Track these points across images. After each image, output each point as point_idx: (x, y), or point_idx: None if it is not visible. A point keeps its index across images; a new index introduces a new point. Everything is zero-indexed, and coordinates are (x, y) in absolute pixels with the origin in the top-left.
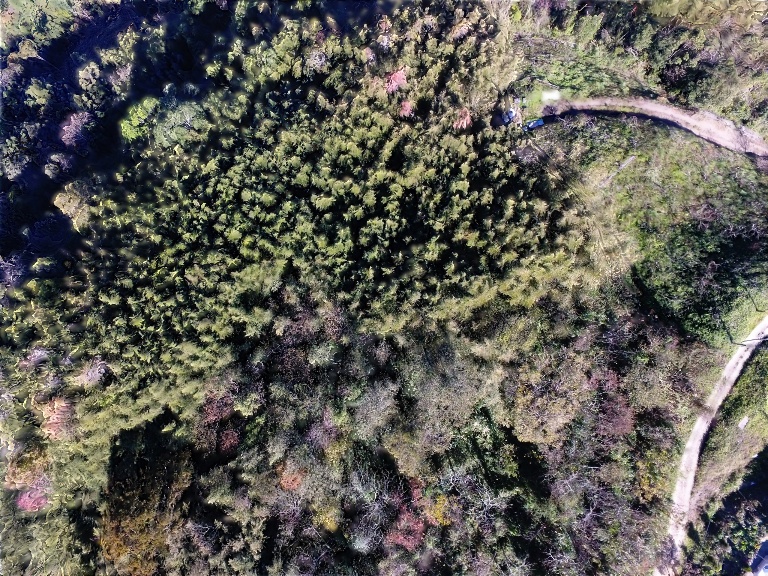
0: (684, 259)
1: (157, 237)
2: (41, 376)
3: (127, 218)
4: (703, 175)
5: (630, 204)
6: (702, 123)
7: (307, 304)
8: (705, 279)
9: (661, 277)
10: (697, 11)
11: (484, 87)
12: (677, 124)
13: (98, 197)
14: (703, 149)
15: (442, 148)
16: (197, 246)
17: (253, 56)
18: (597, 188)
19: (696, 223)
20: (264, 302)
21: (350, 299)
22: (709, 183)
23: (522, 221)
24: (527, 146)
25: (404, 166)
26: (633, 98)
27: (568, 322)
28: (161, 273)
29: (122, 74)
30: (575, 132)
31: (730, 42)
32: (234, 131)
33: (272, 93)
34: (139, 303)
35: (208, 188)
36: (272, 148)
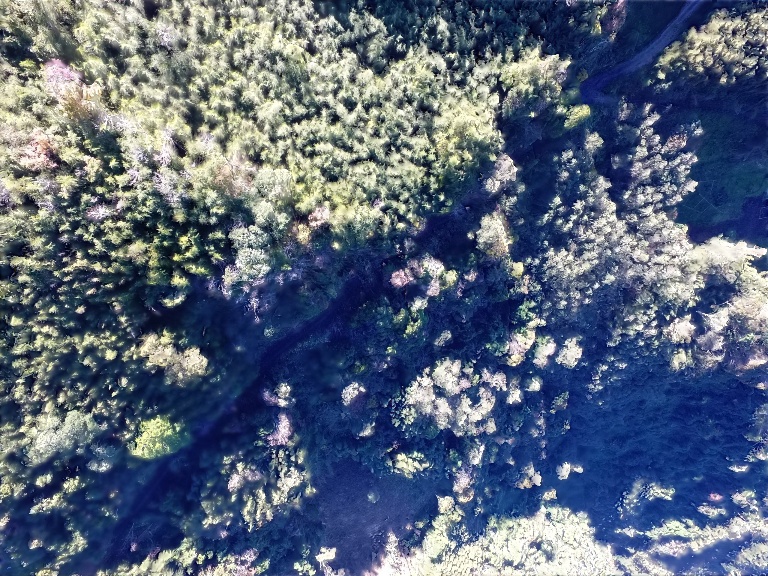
0: None
1: (7, 322)
2: (98, 189)
3: (72, 342)
4: None
5: None
6: None
7: None
8: None
9: None
10: None
11: None
12: None
13: None
14: None
15: None
16: None
17: None
18: None
19: None
20: None
21: None
22: None
23: None
24: None
25: None
26: None
27: None
28: None
29: None
30: None
31: None
32: None
33: None
34: None
35: None
36: None
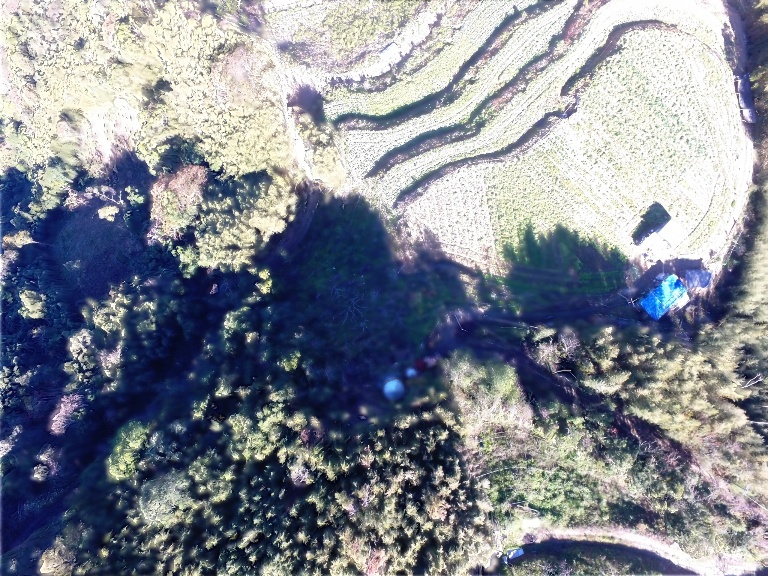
0: None
1: None
2: None
3: None
4: None
5: None
6: (681, 552)
7: None
8: None
9: None
10: (677, 423)
11: None
12: (656, 554)
13: (84, 570)
14: None
15: None
16: None
17: (239, 420)
18: None
19: None
20: None
21: None
22: None
23: None
24: None
25: None
26: (613, 527)
27: None
28: None
29: (112, 358)
30: None
31: (709, 469)
32: (218, 523)
33: (257, 480)
34: None
35: None
36: (255, 569)
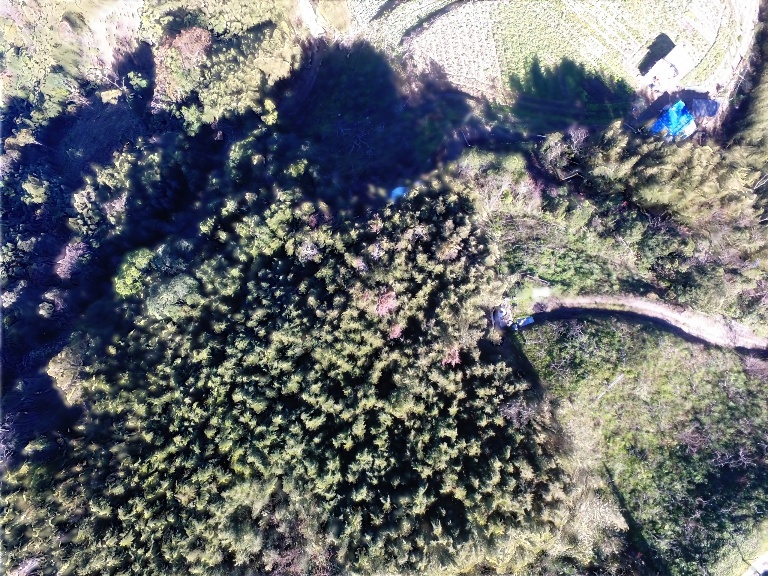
0: (672, 489)
1: (148, 435)
2: None
3: (119, 405)
4: (692, 386)
5: (619, 425)
6: (692, 320)
7: (296, 535)
8: (692, 520)
9: (649, 510)
10: (687, 201)
11: (473, 316)
12: (667, 322)
13: (91, 369)
14: (692, 357)
15: (431, 381)
16: (188, 451)
17: (246, 224)
18: (586, 409)
19: (684, 444)
20: (254, 525)
21: (338, 544)
22: (698, 395)
23: (509, 488)
24: (515, 391)
25: (393, 395)
26: (623, 295)
27: (556, 558)
28: (152, 483)
29: (117, 205)
30: (565, 342)
31: (720, 238)
32: (226, 311)
33: (264, 271)
34: (130, 518)
35: (200, 381)
36: (264, 342)
